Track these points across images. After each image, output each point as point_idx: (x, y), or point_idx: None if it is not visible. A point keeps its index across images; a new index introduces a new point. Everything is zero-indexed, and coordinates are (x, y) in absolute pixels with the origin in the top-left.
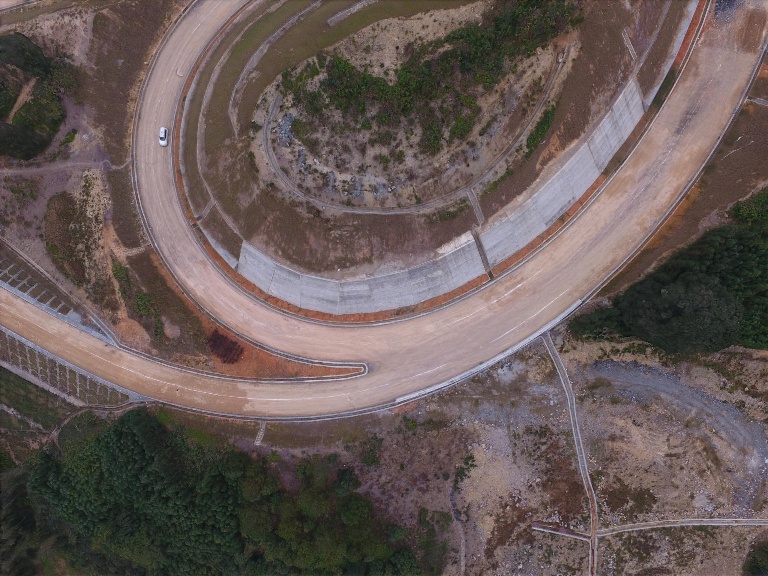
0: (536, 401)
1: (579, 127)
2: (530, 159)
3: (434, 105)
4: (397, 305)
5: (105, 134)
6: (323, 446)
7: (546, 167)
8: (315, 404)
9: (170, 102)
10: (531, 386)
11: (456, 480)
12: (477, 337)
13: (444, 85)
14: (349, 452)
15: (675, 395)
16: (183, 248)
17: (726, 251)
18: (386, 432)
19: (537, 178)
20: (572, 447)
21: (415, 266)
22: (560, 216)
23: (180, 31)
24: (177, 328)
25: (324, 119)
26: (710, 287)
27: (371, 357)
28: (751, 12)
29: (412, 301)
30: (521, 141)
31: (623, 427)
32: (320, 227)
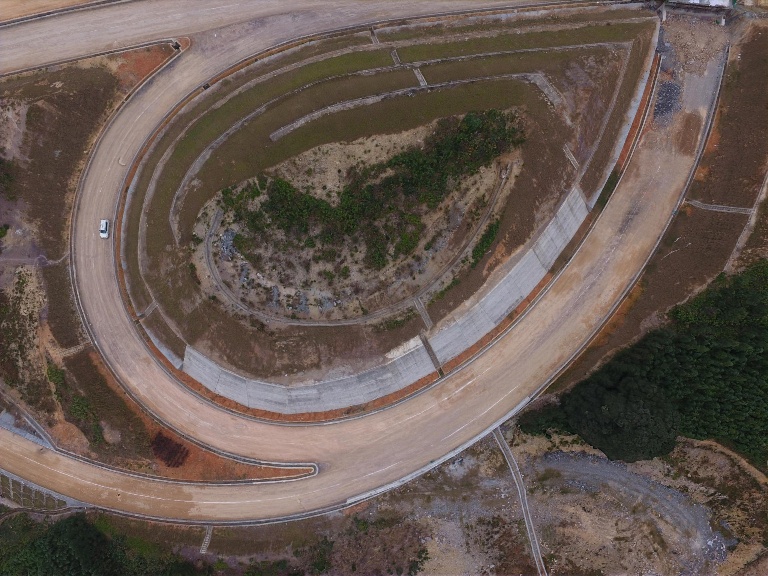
0: (488, 495)
1: (524, 234)
2: (476, 268)
3: (378, 224)
4: (347, 404)
5: (40, 228)
6: (272, 552)
7: (493, 272)
8: (264, 506)
9: (112, 192)
10: (482, 480)
11: (410, 574)
12: (428, 435)
13: (387, 206)
14: (299, 558)
15: (622, 482)
16: (125, 345)
17: (665, 357)
18: (337, 534)
19: (484, 283)
20: (524, 534)
21: (364, 371)
22: (509, 314)
23: (122, 119)
24: (118, 433)
25: (266, 236)
26: (649, 397)
27: (321, 457)
28: (687, 117)
29: (363, 400)
30: (467, 253)
31: (573, 514)
32: (265, 339)
